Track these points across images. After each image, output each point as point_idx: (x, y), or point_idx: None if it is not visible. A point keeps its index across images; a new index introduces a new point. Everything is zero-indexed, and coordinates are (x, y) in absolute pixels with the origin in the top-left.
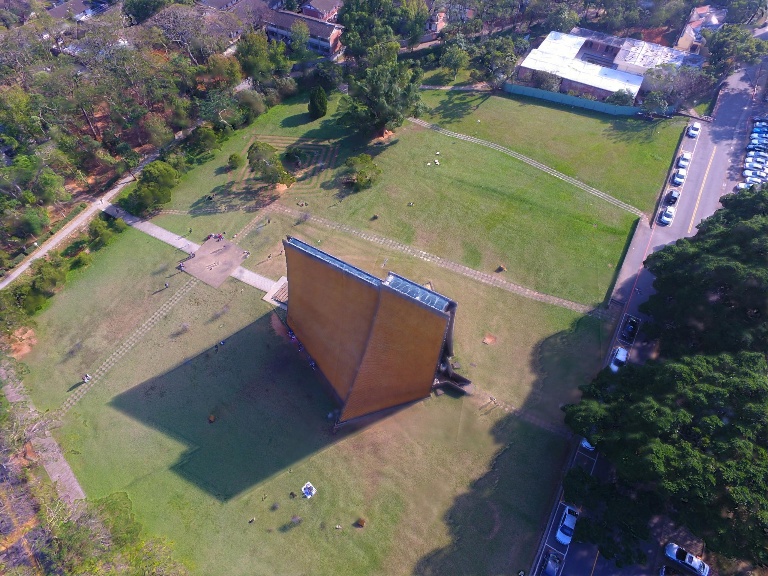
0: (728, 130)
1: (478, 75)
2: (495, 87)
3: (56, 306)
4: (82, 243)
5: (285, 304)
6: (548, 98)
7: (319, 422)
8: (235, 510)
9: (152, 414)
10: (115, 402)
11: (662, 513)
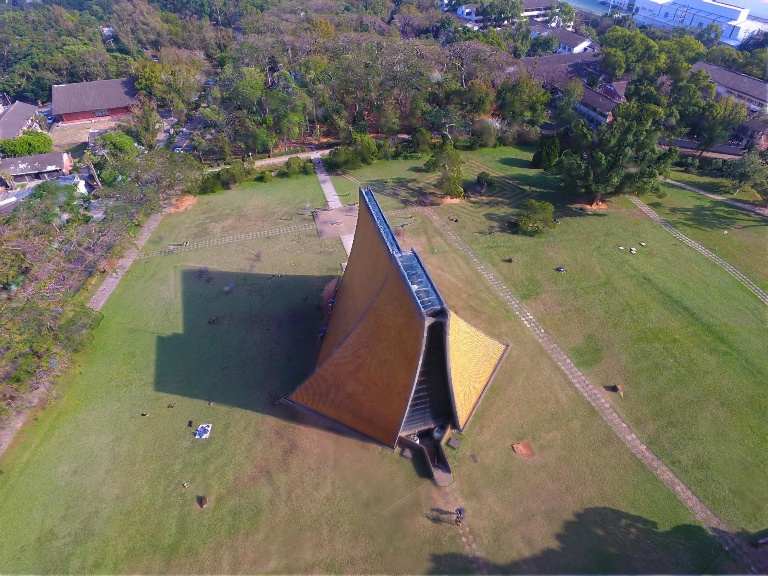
0: None
1: (764, 188)
2: None
3: (223, 195)
4: None
5: None
6: None
7: (274, 385)
8: (146, 396)
9: (187, 290)
10: (180, 268)
11: None
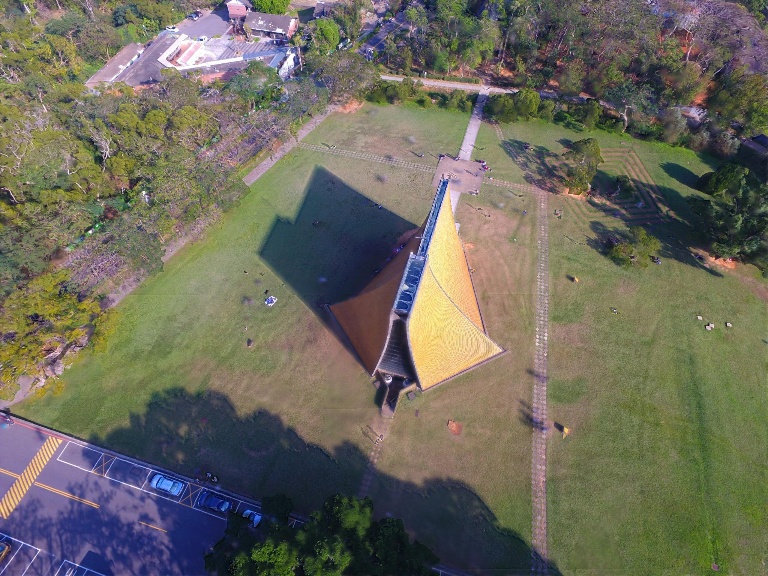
0: None
1: None
2: None
3: (383, 109)
4: (445, 98)
5: None
6: None
7: (326, 292)
8: (252, 260)
9: (313, 190)
10: (319, 168)
11: None
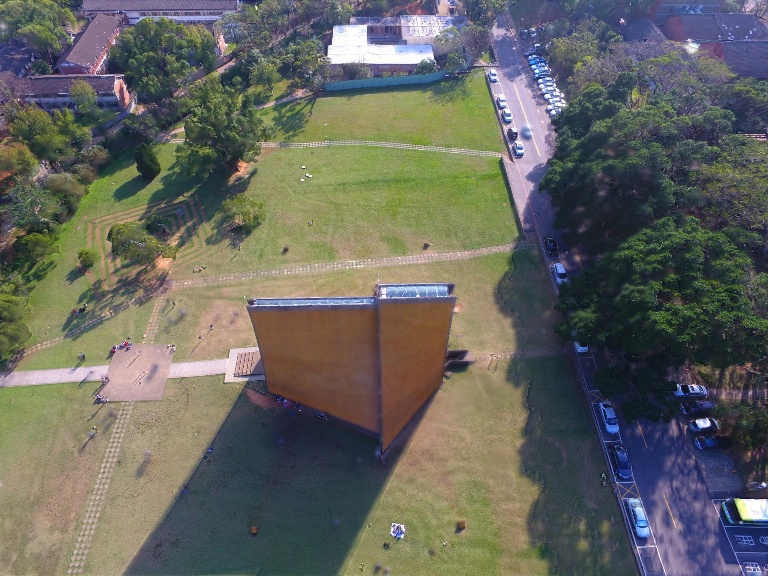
0: (514, 69)
1: (300, 83)
2: (316, 90)
3: None
4: None
5: (254, 375)
6: (367, 85)
7: (364, 464)
8: None
9: (179, 571)
10: None
11: (671, 365)
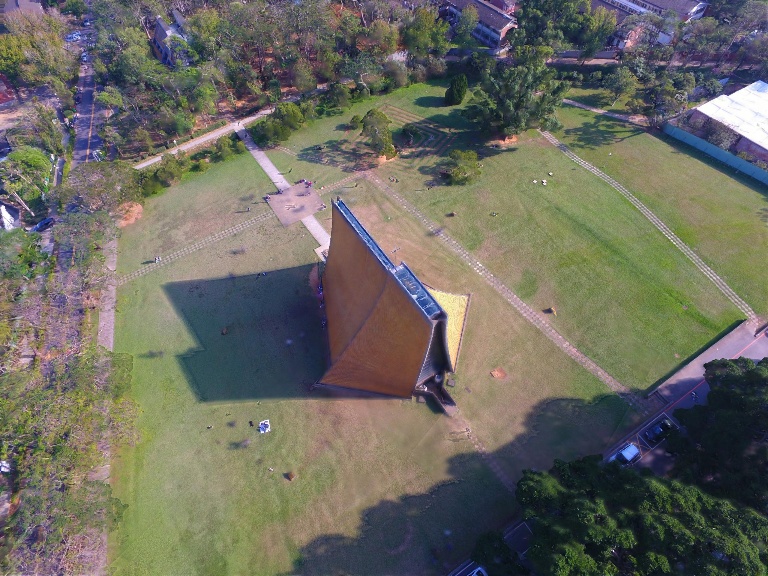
0: None
1: (635, 105)
2: (653, 124)
3: (167, 195)
4: (210, 153)
5: None
6: (711, 153)
7: (303, 374)
8: (203, 412)
9: (186, 307)
10: (167, 286)
11: None
